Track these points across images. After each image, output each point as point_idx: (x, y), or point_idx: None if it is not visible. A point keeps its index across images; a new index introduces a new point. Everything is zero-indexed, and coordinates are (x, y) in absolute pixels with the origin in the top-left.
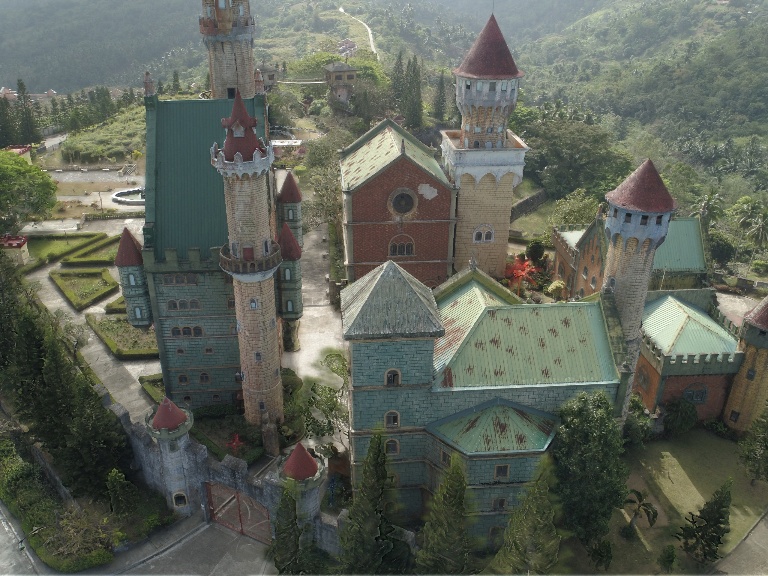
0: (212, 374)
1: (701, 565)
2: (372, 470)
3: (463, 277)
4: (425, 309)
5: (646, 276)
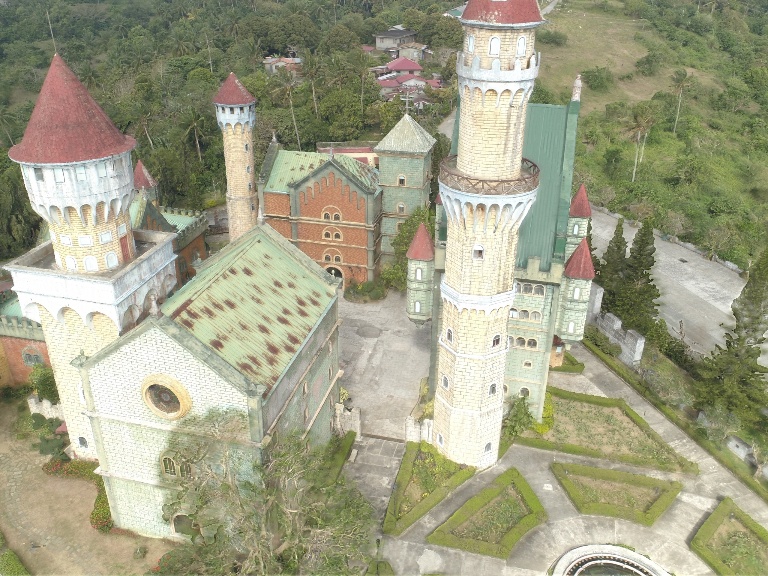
0: None
1: None
2: None
3: None
4: None
5: None
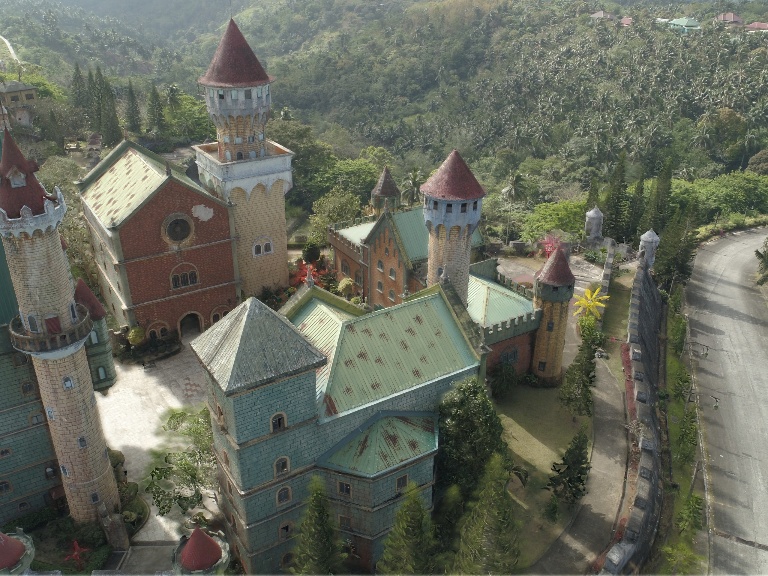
0: (13, 480)
1: (572, 506)
2: (320, 530)
3: (303, 297)
4: (302, 341)
5: (468, 259)
